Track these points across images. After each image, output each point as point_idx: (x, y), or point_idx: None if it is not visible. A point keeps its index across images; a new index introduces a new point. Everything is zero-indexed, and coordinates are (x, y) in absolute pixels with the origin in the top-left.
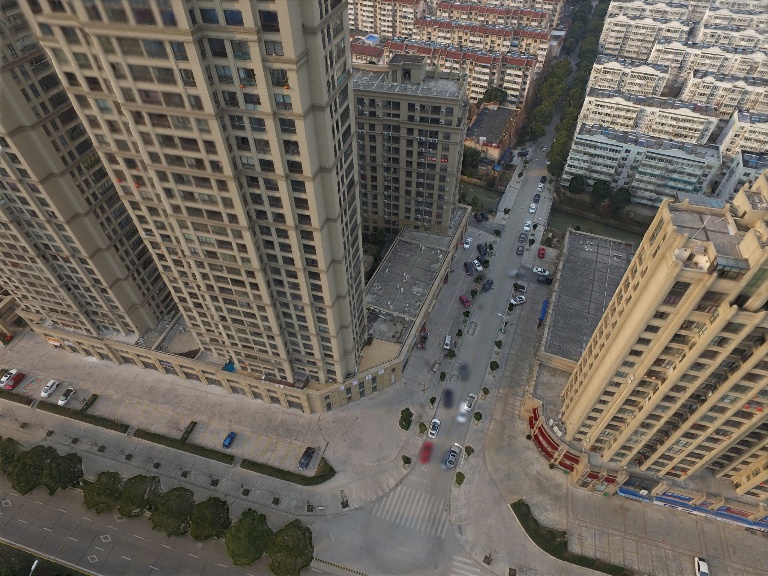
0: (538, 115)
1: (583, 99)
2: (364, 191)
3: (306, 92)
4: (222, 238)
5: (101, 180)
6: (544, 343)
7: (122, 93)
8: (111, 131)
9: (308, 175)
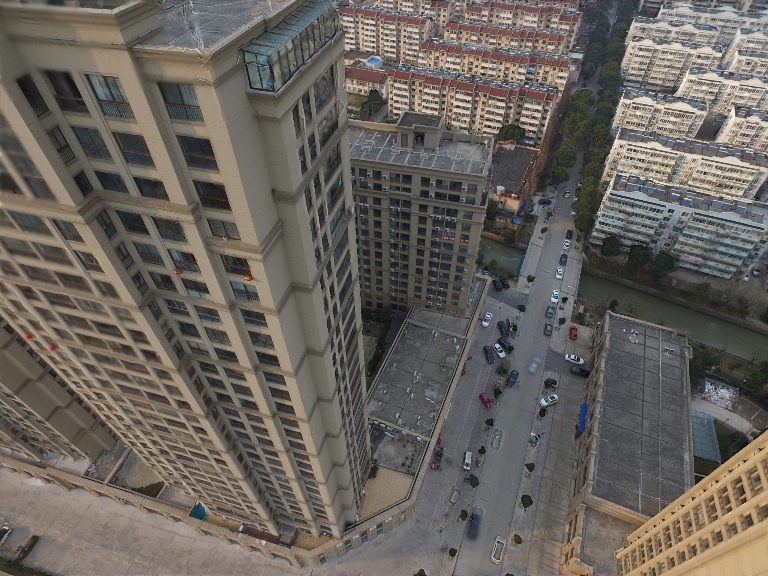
0: (560, 156)
1: (609, 136)
2: (367, 267)
3: (281, 275)
4: (172, 418)
5: None
6: (591, 483)
7: None
8: (2, 290)
9: (288, 370)
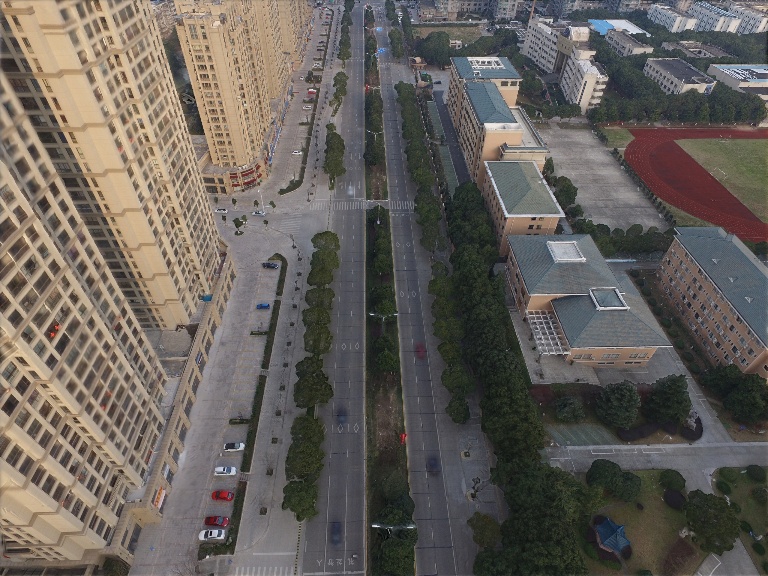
0: None
1: None
2: None
3: None
4: (172, 139)
5: None
6: None
7: (120, 39)
8: (110, 93)
9: None
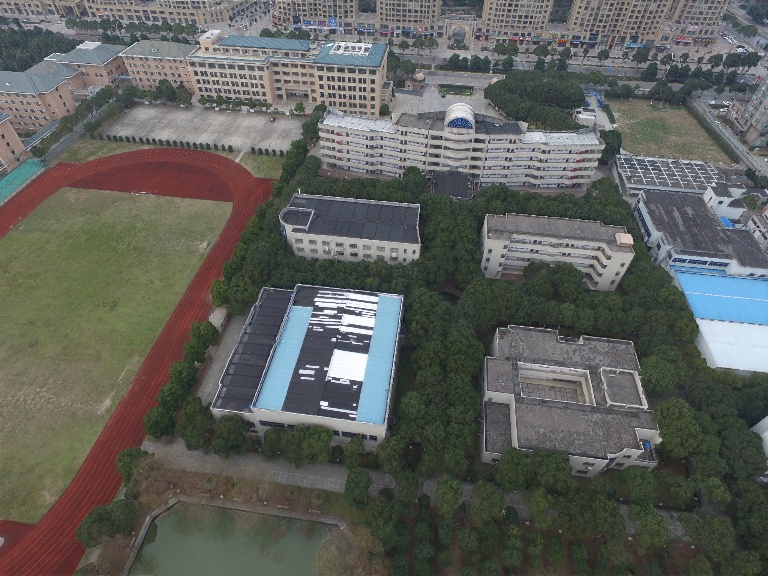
0: None
1: None
2: None
3: None
4: None
5: None
6: None
7: None
8: None
9: None
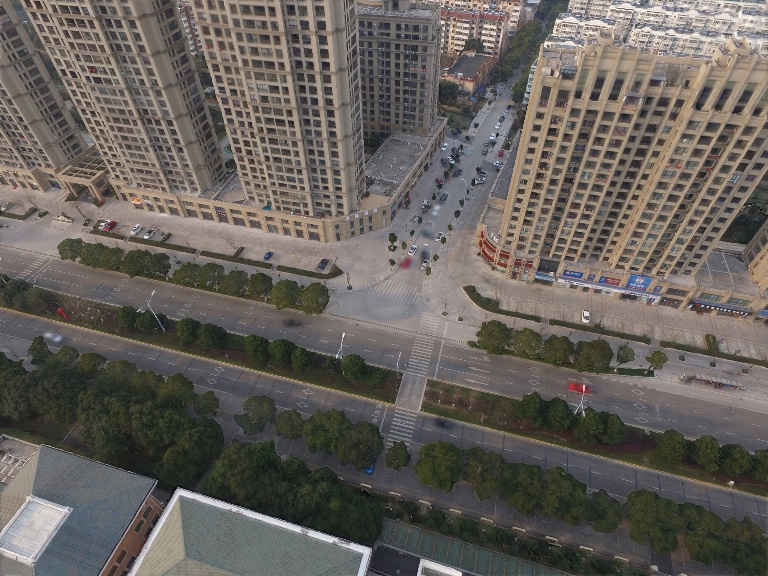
0: (508, 60)
1: None
2: (364, 100)
3: None
4: (273, 84)
5: (185, 64)
6: (491, 191)
7: None
8: (209, 8)
9: (329, 30)
